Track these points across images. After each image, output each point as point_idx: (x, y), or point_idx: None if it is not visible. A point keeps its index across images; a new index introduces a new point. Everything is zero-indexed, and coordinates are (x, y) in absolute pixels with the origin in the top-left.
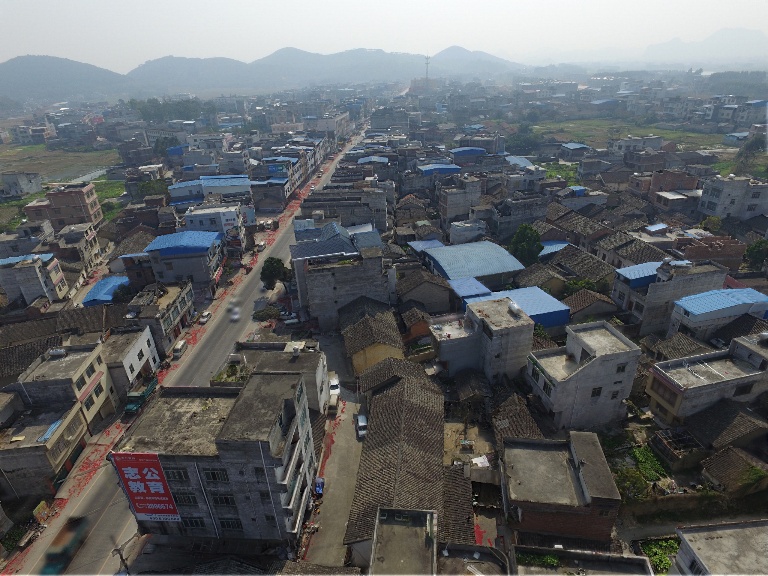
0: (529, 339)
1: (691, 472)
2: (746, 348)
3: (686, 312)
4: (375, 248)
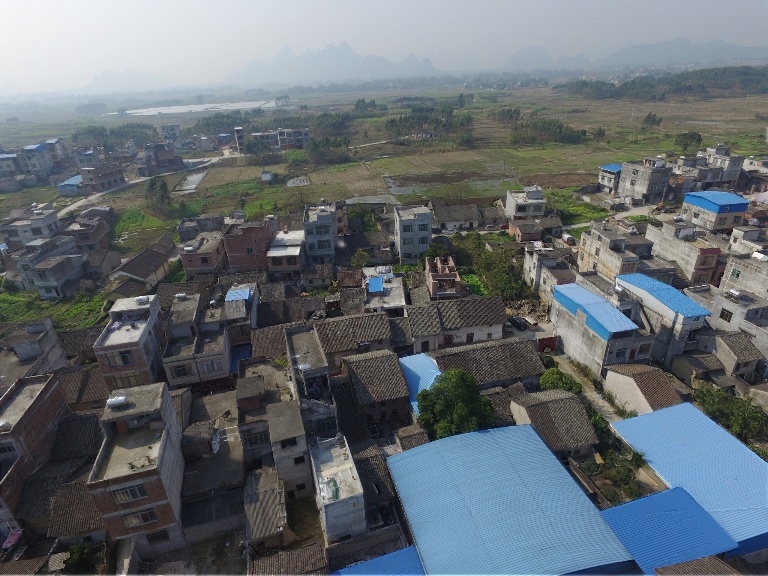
0: None
1: None
2: None
3: (697, 318)
4: None
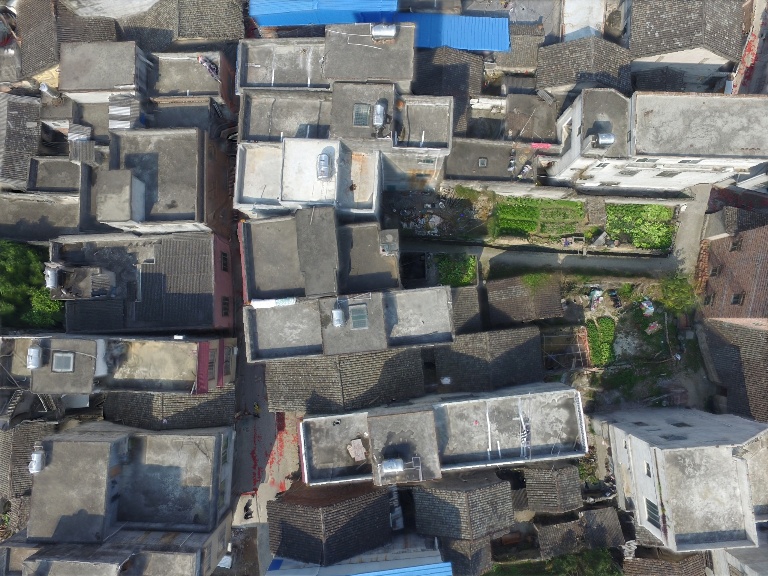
0: (760, 569)
1: (556, 322)
2: None
3: None
4: None
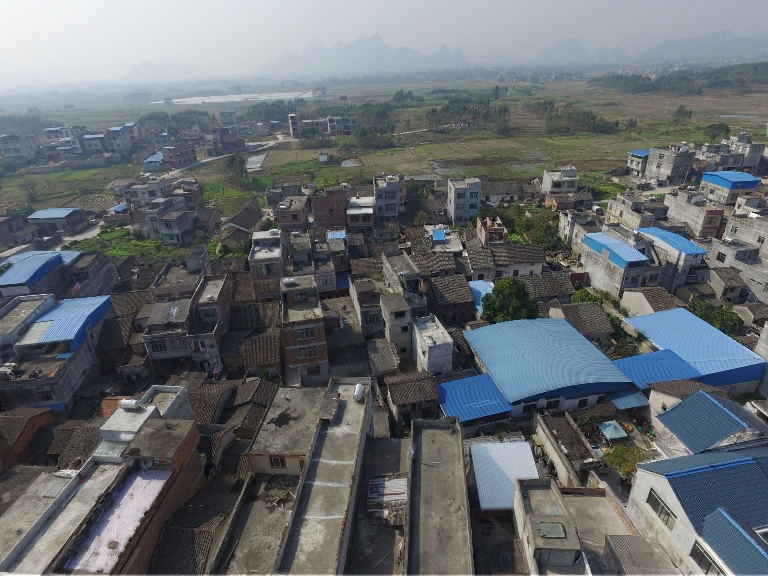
0: None
1: None
2: (743, 251)
3: None
4: (767, 407)
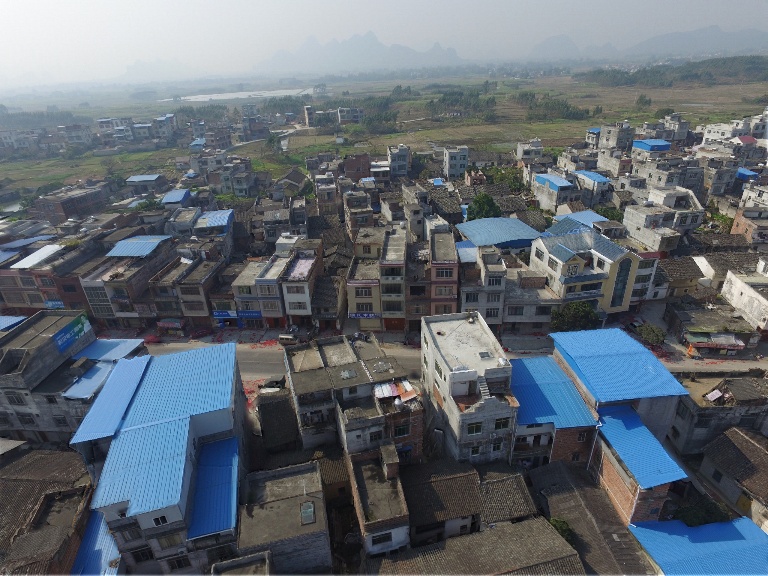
0: None
1: None
2: None
3: (604, 183)
4: (598, 223)
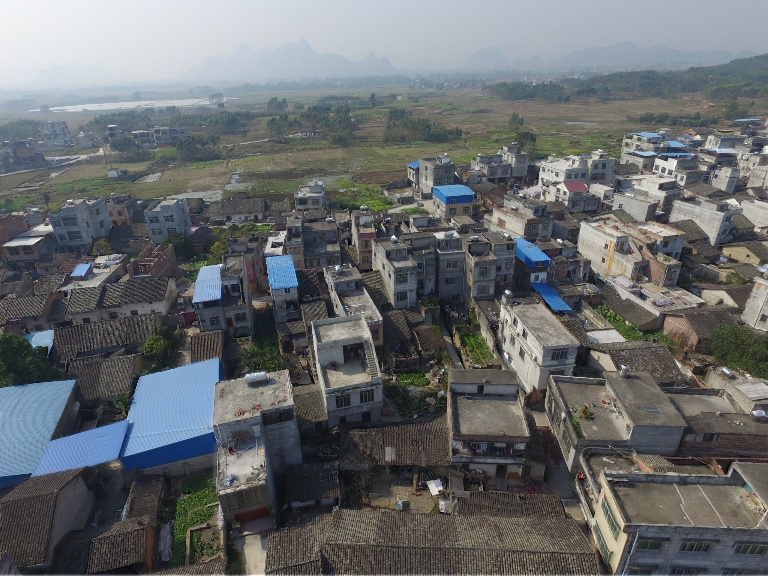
0: None
1: None
2: (344, 282)
3: (287, 290)
4: None
